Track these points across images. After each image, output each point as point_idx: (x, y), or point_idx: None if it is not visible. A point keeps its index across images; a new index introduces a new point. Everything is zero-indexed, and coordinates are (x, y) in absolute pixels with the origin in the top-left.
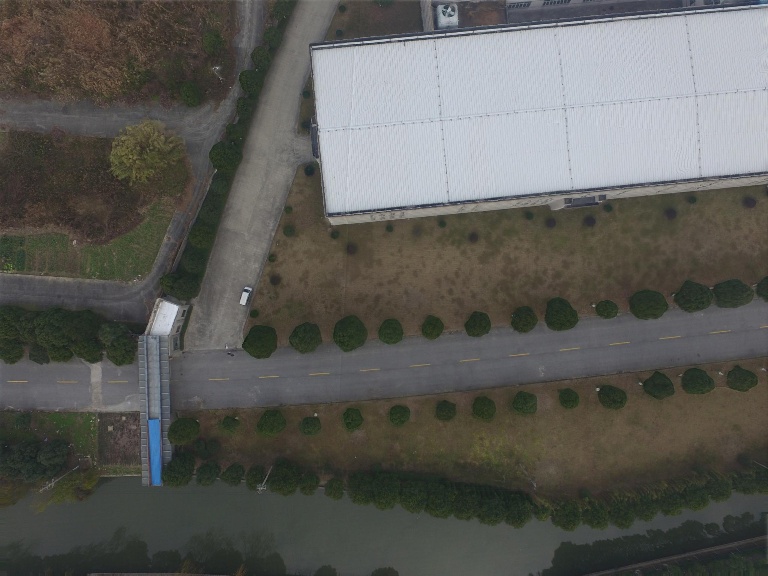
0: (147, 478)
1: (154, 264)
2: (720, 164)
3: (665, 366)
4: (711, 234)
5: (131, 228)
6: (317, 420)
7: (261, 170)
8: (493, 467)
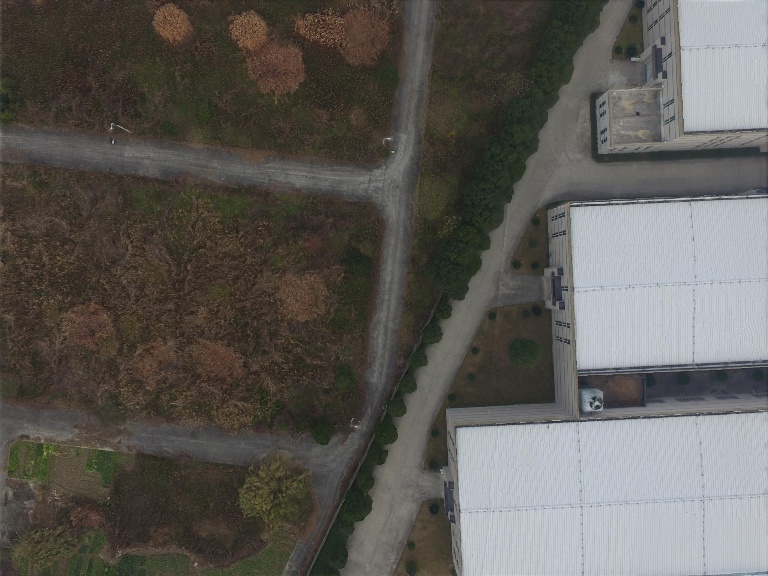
0: None
1: None
2: None
3: None
4: None
5: (253, 554)
6: None
7: (386, 504)
8: None
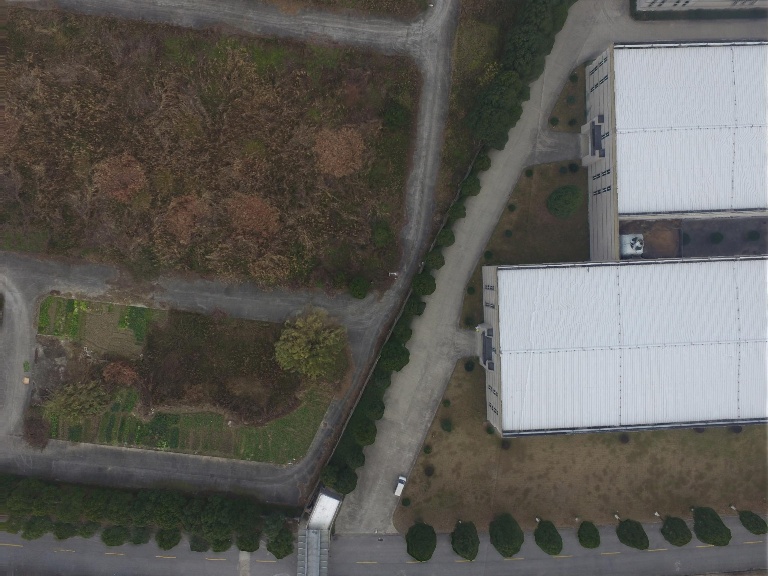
0: None
1: (309, 449)
2: None
3: None
4: None
5: (288, 412)
6: None
7: (421, 362)
8: None
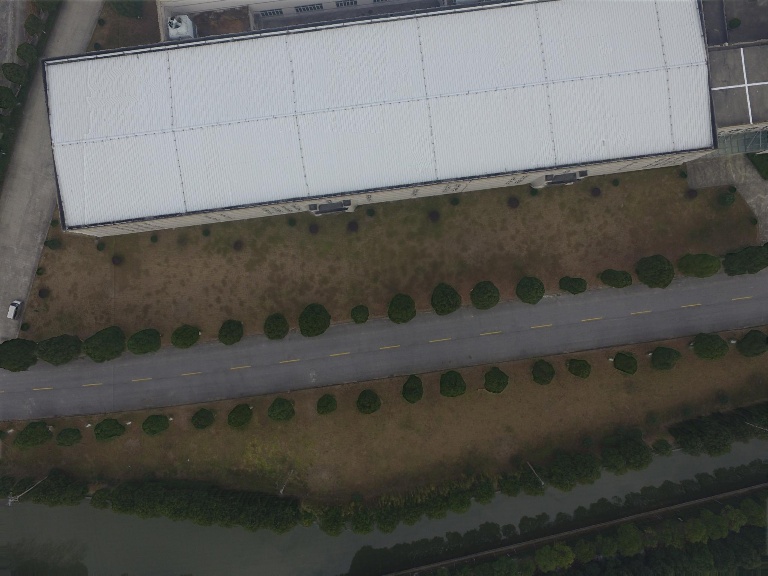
0: None
1: None
2: (456, 166)
3: (437, 369)
4: (477, 235)
5: None
6: (73, 431)
7: (28, 184)
8: (266, 474)
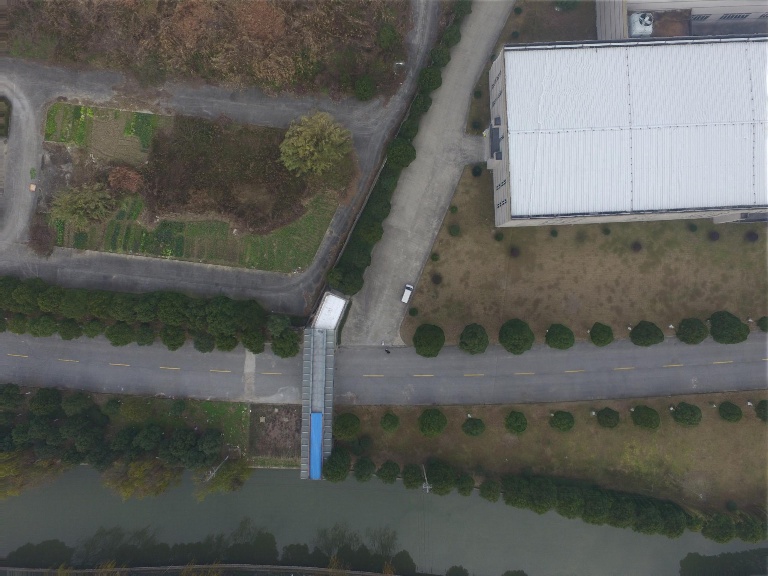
0: (306, 472)
1: (315, 257)
2: None
3: None
4: None
5: (293, 220)
6: None
7: (428, 168)
8: (642, 476)
